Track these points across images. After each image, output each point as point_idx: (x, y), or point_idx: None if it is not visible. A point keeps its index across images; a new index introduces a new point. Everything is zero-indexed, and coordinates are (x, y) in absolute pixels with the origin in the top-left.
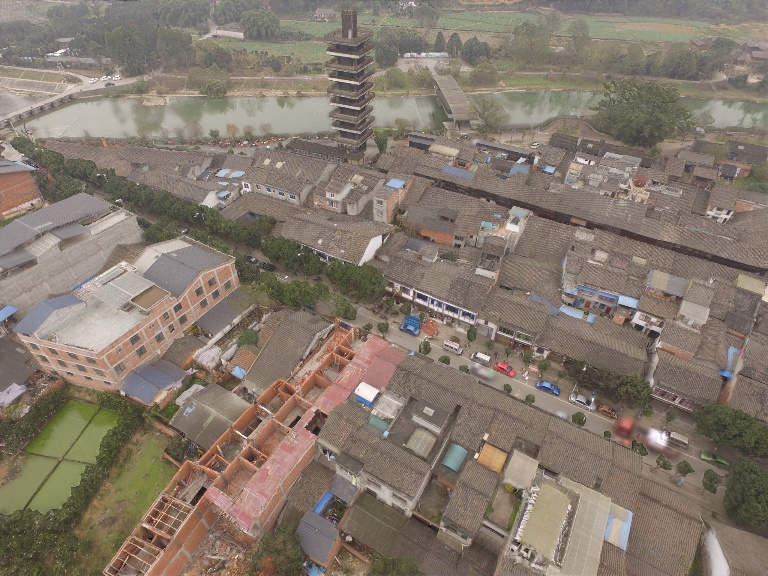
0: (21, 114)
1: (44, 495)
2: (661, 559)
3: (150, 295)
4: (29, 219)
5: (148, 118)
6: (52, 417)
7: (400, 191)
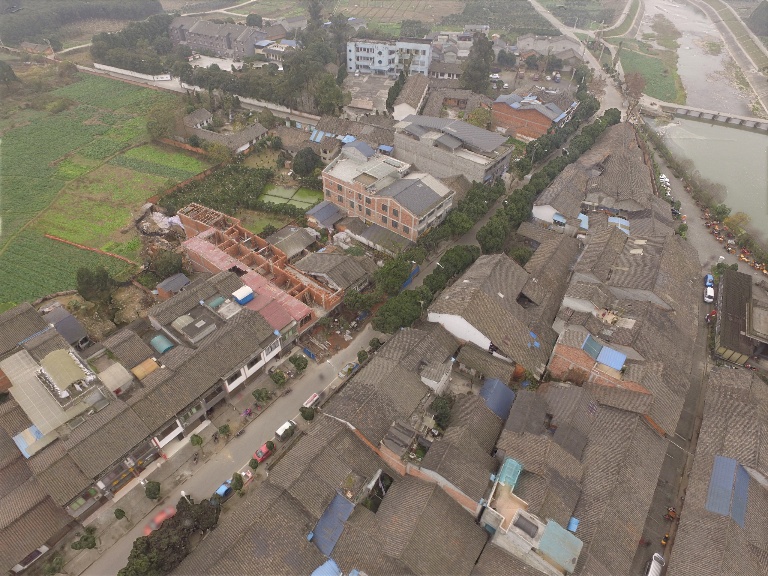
0: (703, 113)
1: (270, 198)
2: (0, 504)
3: (368, 179)
4: (459, 124)
5: (764, 176)
6: (321, 191)
7: (613, 375)
